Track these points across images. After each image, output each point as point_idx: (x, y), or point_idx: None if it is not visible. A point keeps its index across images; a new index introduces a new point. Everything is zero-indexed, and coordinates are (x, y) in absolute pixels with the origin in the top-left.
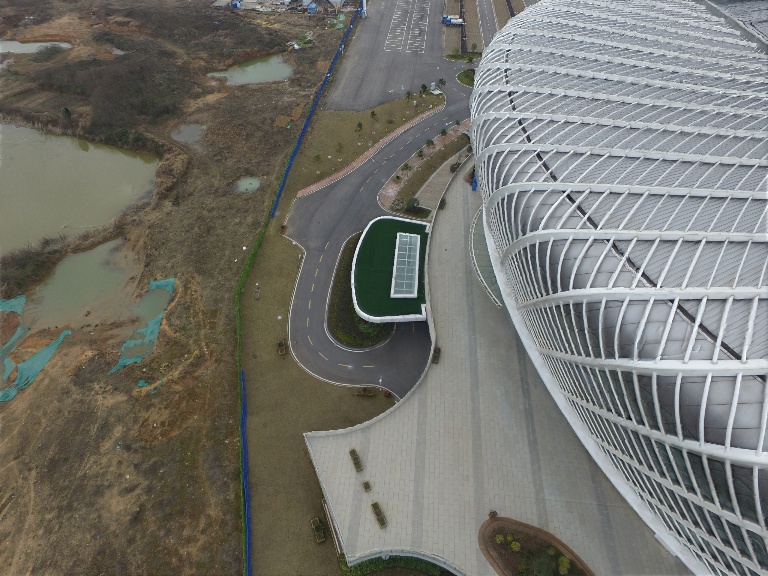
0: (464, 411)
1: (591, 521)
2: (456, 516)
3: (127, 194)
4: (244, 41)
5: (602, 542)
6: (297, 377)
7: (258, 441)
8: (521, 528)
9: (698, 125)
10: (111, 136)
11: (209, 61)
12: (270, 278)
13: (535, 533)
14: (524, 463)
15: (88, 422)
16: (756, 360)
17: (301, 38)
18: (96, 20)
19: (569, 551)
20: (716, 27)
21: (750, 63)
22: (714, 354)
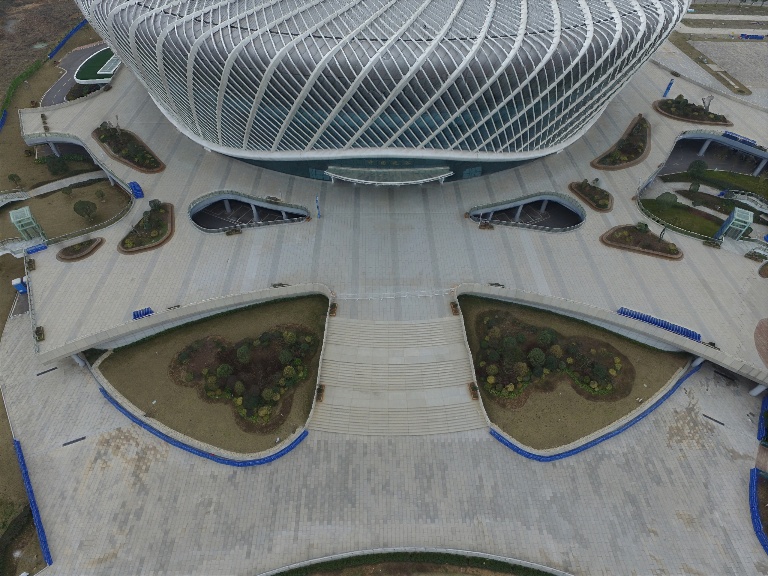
0: (111, 103)
1: None
2: (85, 128)
3: None
4: None
5: (150, 131)
6: None
7: (7, 132)
8: None
9: None
10: None
11: None
12: (39, 82)
13: None
14: (130, 115)
15: None
16: None
17: None
18: None
19: (131, 132)
20: None
21: None
22: None
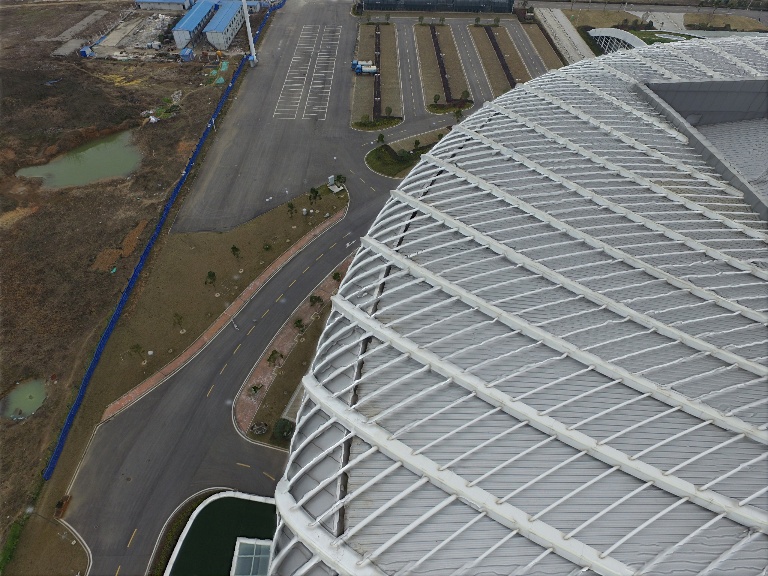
0: None
1: None
2: None
3: None
4: (79, 114)
5: None
6: None
7: None
8: None
9: None
10: None
11: (21, 151)
12: None
13: None
14: None
15: None
16: None
17: (164, 103)
18: None
19: None
20: None
21: None
22: None
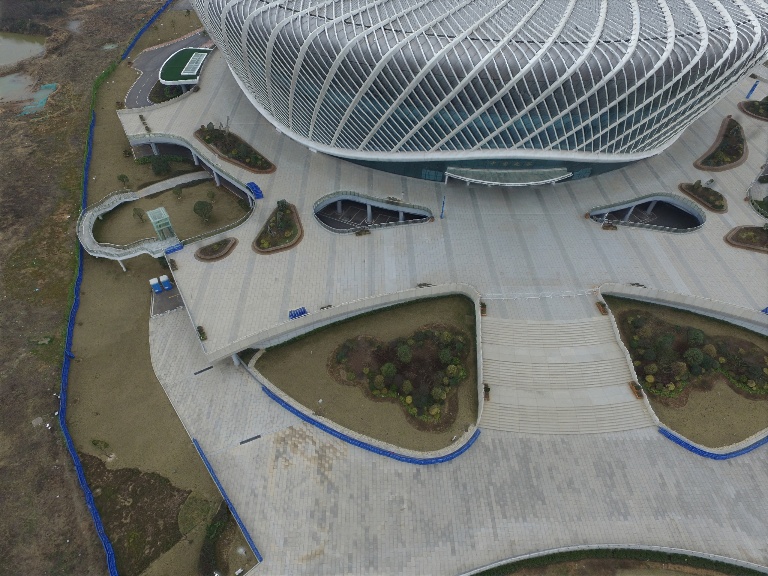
0: (204, 104)
1: (249, 127)
2: (186, 129)
3: (26, 53)
4: None
5: None
6: None
7: (100, 133)
8: None
9: None
10: (14, 26)
11: None
12: (118, 82)
13: None
14: None
15: (4, 129)
16: None
17: None
18: None
19: (233, 133)
20: None
21: None
22: None
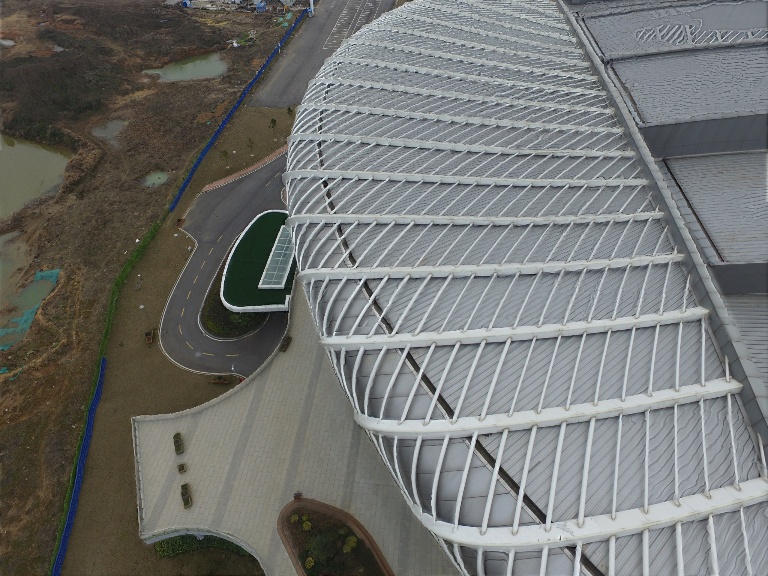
0: (298, 397)
1: (393, 503)
2: (262, 497)
3: (35, 188)
4: (184, 39)
5: (398, 523)
6: (158, 365)
7: (104, 426)
8: (320, 509)
9: (469, 115)
10: (30, 131)
11: (145, 58)
12: (156, 270)
13: (333, 513)
14: (343, 447)
15: None
16: (403, 334)
17: (243, 36)
18: (44, 18)
19: (362, 531)
20: (550, 23)
21: (558, 57)
22: (372, 329)
